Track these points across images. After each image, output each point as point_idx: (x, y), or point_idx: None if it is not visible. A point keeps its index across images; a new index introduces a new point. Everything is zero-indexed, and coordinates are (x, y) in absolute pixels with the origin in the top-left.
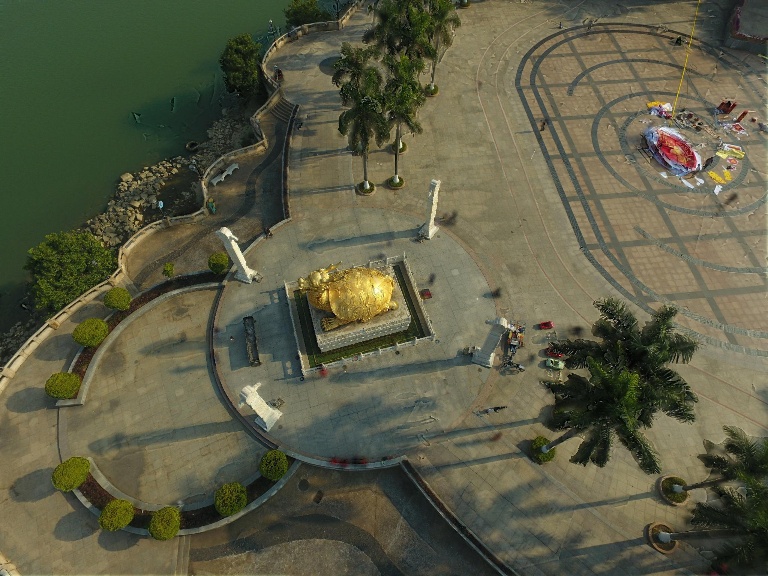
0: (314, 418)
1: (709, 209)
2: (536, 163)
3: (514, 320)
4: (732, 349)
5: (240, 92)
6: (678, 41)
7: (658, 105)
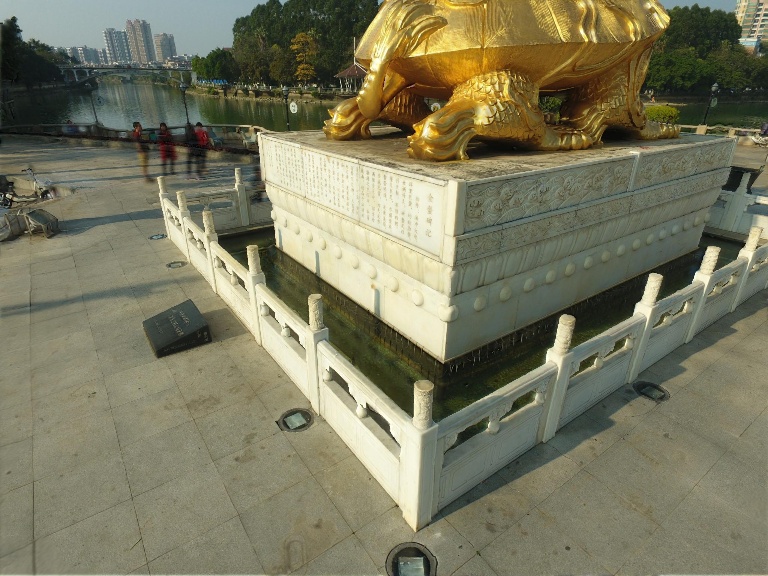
0: None
1: None
2: None
3: None
4: None
5: None
6: None
7: None
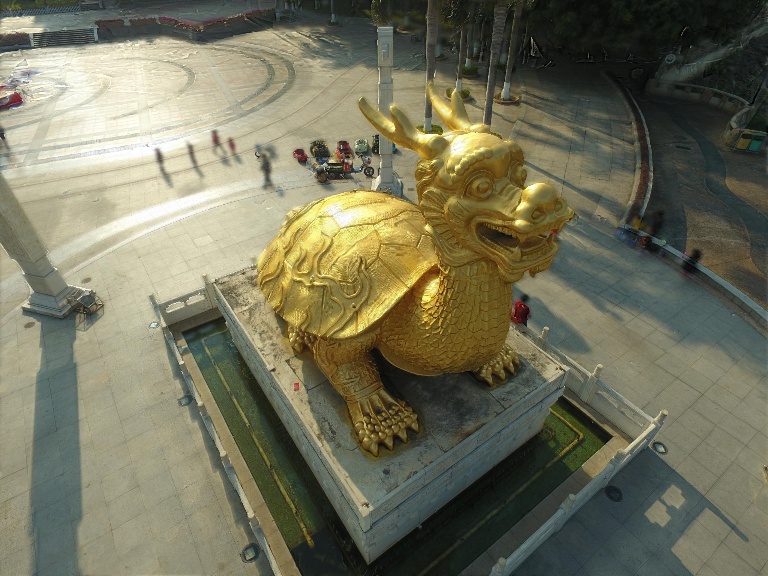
0: (714, 376)
1: (94, 90)
2: None
3: (307, 166)
4: (292, 81)
5: None
6: None
7: None
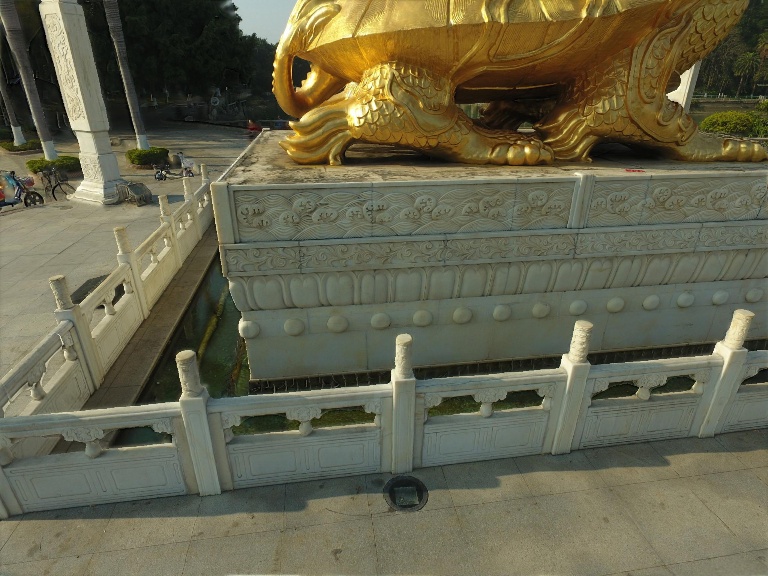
0: None
1: None
2: None
3: None
4: None
5: None
6: None
7: None
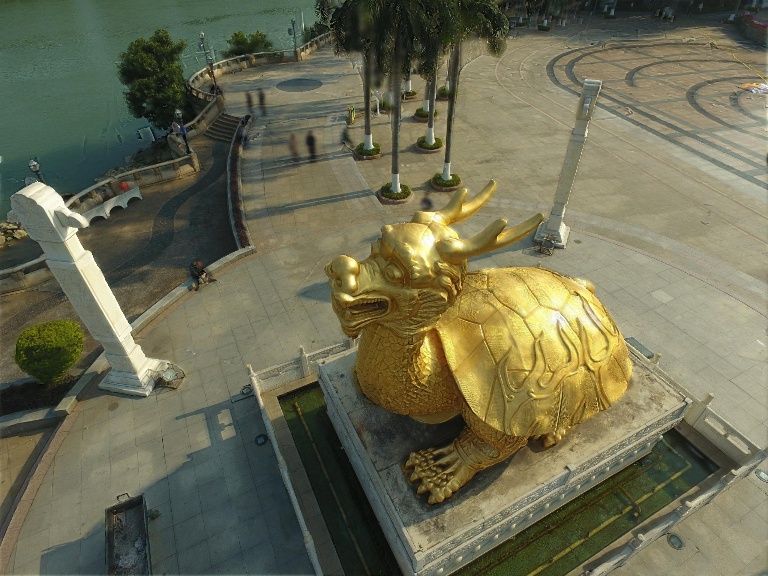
0: None
1: None
2: (654, 143)
3: None
4: None
5: (153, 122)
6: (713, 45)
7: (754, 84)
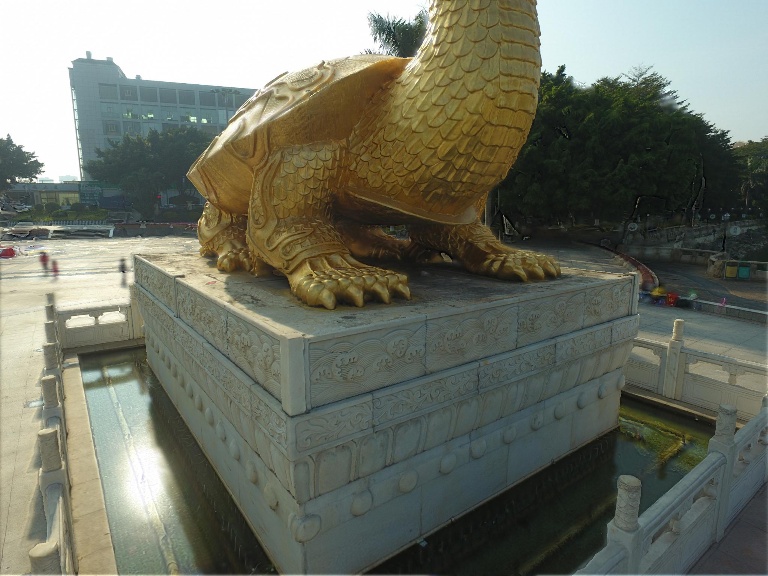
0: None
1: None
2: None
3: None
4: None
5: None
6: None
7: None
